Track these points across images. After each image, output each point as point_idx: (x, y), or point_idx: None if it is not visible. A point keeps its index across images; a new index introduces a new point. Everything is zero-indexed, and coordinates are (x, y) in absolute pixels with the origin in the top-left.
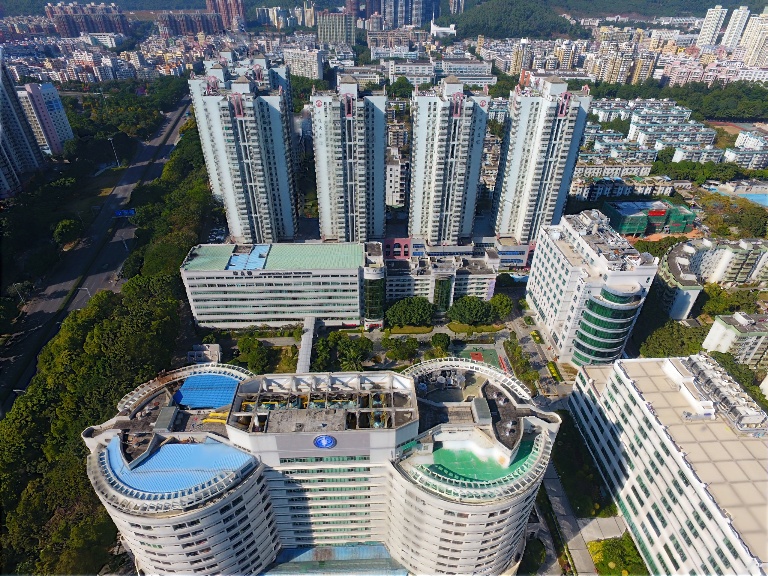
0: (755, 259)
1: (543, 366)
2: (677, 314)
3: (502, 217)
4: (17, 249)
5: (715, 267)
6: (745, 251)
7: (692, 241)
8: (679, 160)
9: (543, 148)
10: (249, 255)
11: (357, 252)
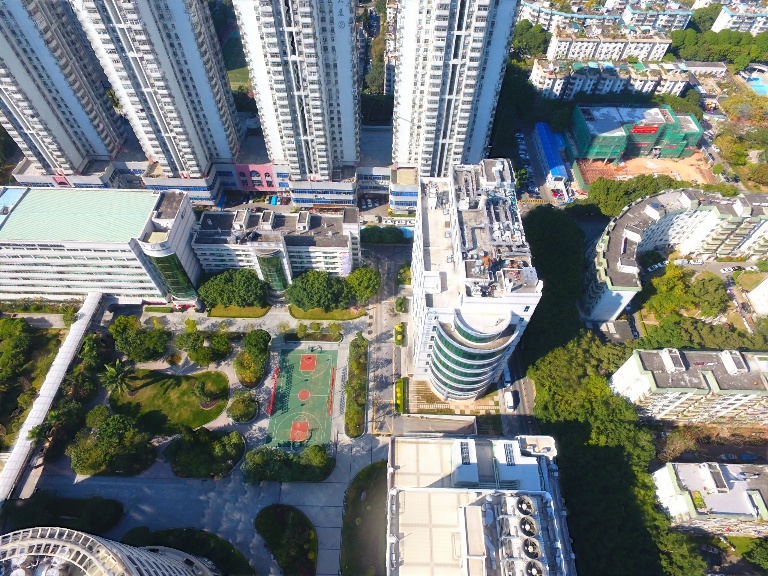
0: (750, 228)
1: (391, 384)
2: (602, 314)
3: (398, 141)
4: None
5: (691, 232)
6: (737, 218)
7: (666, 194)
8: (721, 28)
9: (439, 43)
10: None
11: (143, 209)
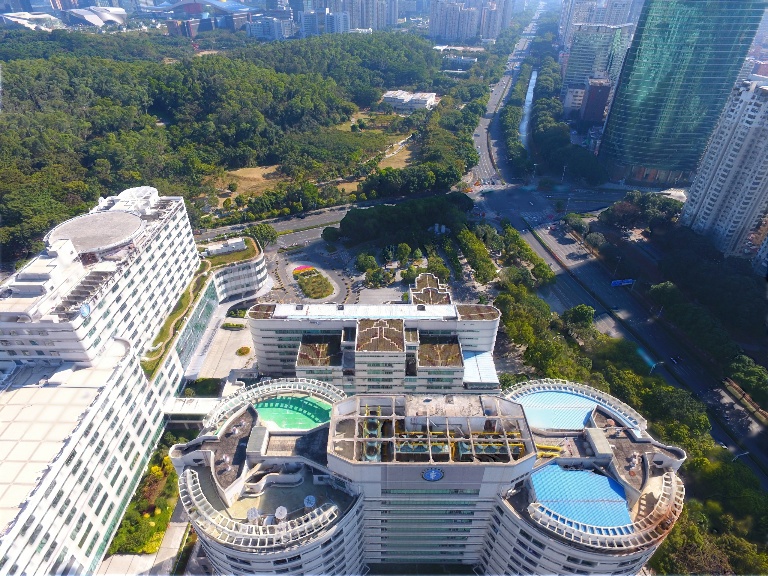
0: None
1: None
2: None
3: None
4: None
5: None
6: None
7: None
8: None
9: None
10: None
11: None
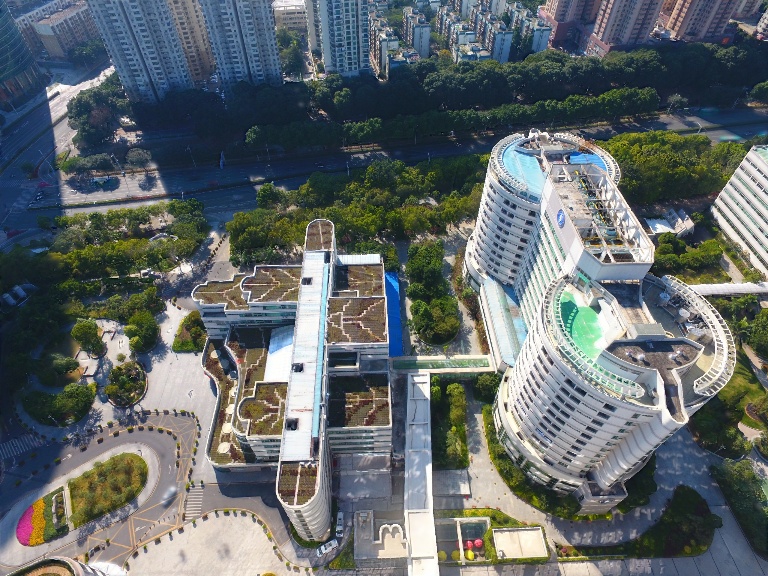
0: None
1: None
2: None
3: None
4: (723, 82)
5: None
6: None
7: None
8: None
9: None
10: None
11: None
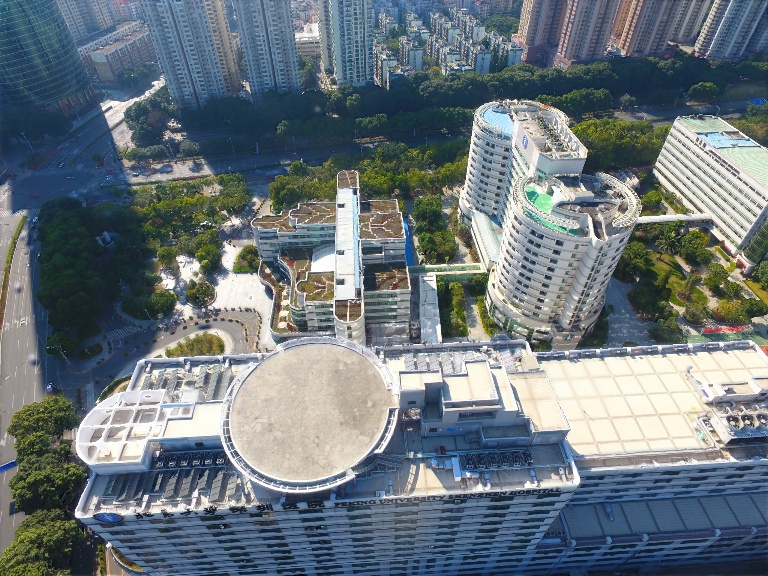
0: None
1: None
2: None
3: None
4: (666, 87)
5: None
6: None
7: None
8: None
9: None
10: (729, 139)
11: None
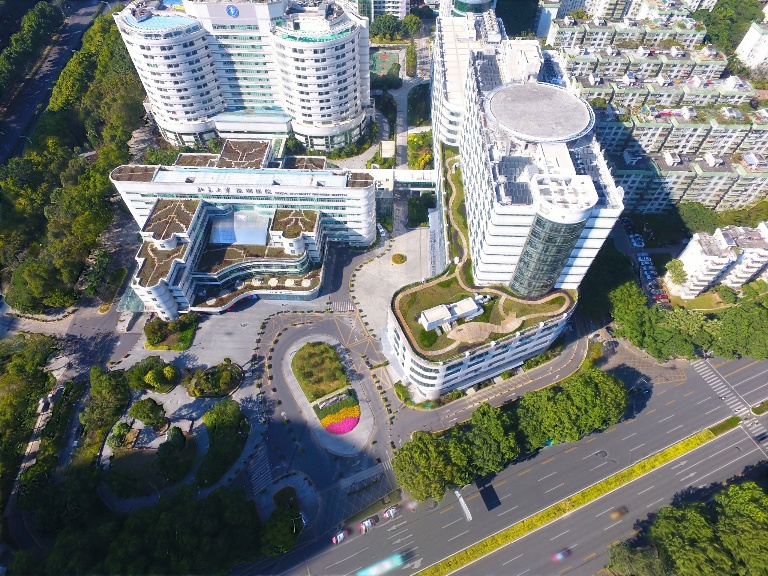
0: None
1: (429, 63)
2: (542, 32)
3: None
4: None
5: (599, 5)
6: None
7: None
8: None
9: None
10: None
11: None
